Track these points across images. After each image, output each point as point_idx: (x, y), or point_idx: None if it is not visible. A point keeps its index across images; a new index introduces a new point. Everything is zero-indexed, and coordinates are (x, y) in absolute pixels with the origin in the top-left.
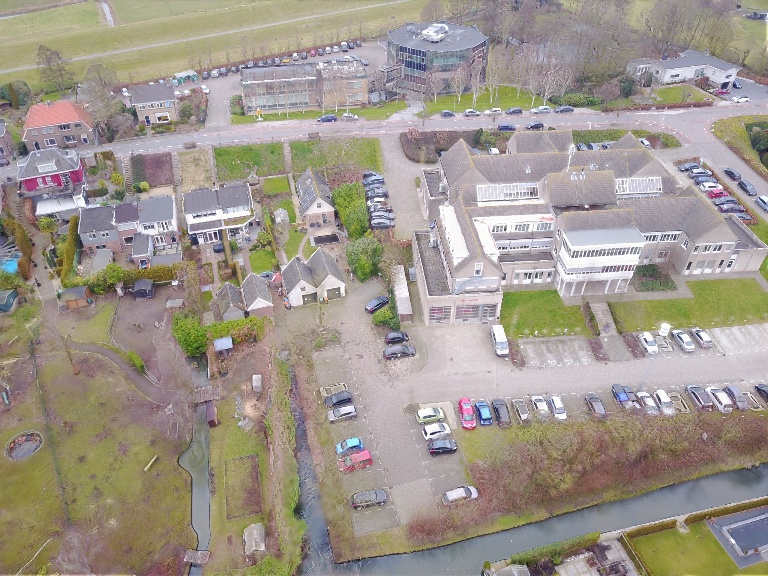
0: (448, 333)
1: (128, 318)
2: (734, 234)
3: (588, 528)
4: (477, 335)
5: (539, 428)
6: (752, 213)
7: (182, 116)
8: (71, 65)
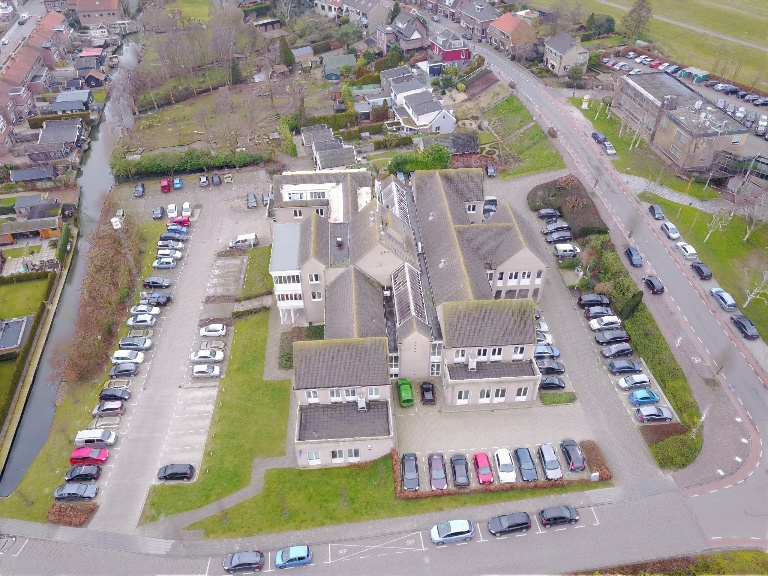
0: (264, 221)
1: (316, 112)
2: (294, 374)
3: (77, 272)
4: (258, 234)
5: (124, 222)
6: (420, 492)
7: (568, 74)
8: (678, 29)
